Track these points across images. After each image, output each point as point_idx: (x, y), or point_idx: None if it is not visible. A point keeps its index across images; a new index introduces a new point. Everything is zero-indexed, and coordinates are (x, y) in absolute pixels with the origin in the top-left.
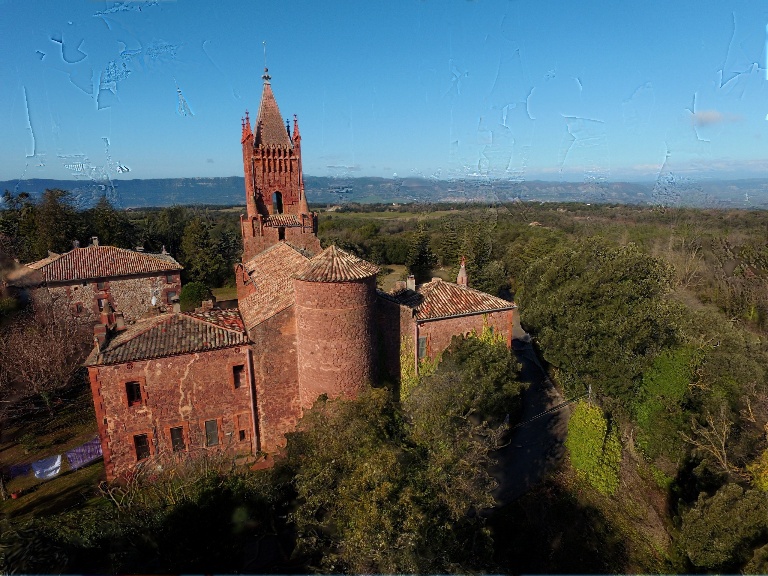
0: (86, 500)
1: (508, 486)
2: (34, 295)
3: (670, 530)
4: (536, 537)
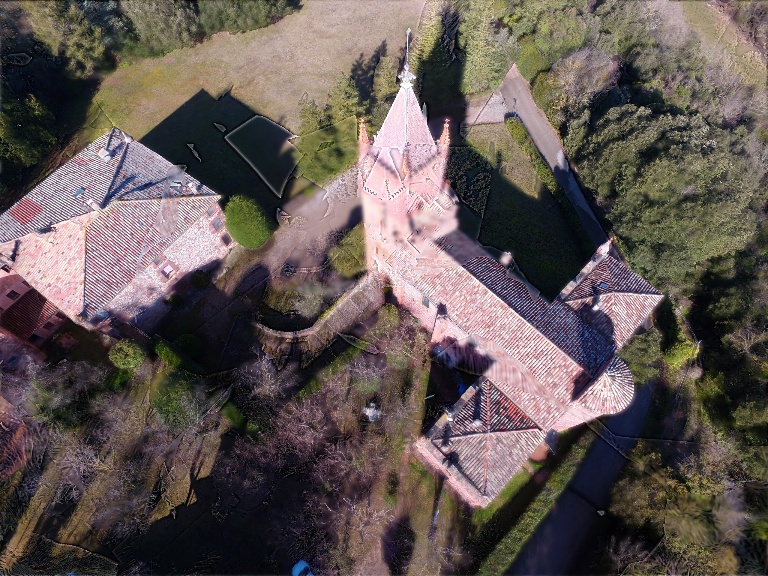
0: (470, 520)
1: (642, 394)
2: (234, 381)
3: (709, 381)
4: (668, 429)
